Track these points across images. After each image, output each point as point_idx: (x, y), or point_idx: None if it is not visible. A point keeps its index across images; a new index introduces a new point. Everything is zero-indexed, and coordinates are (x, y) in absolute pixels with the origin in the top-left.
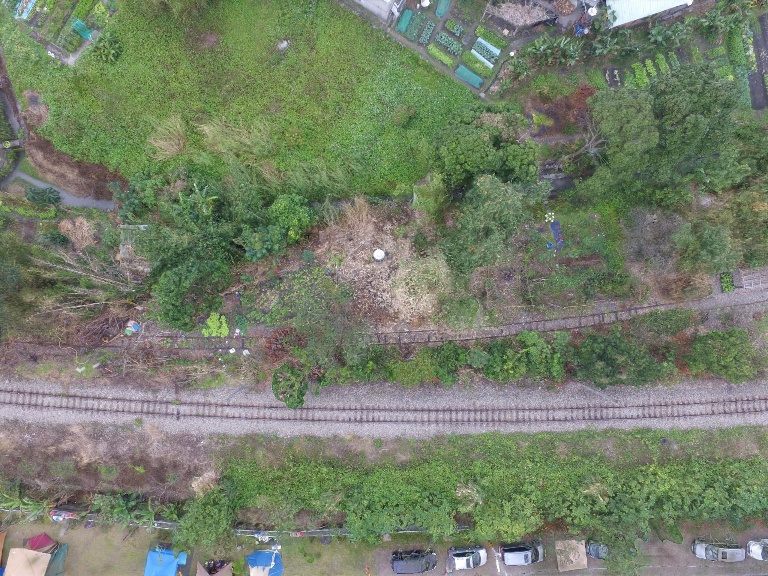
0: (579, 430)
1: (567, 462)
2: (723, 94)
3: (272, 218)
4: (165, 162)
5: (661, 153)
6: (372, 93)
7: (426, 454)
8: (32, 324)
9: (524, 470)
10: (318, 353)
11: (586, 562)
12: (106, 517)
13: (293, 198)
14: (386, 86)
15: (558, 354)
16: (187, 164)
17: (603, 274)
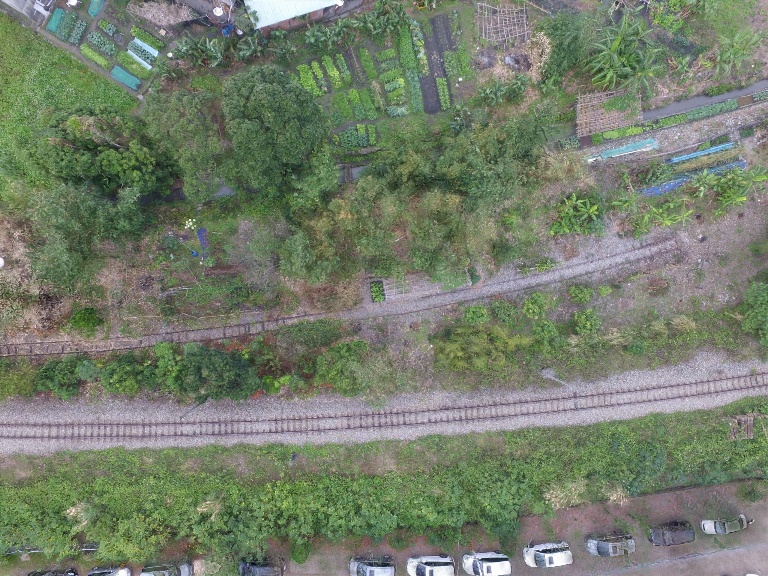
0: (207, 445)
1: (196, 478)
2: (263, 97)
3: None
4: None
5: (243, 158)
6: (21, 94)
7: (46, 471)
8: None
9: (146, 487)
10: None
11: None
12: None
13: None
14: (35, 87)
15: (177, 366)
16: None
17: (251, 283)
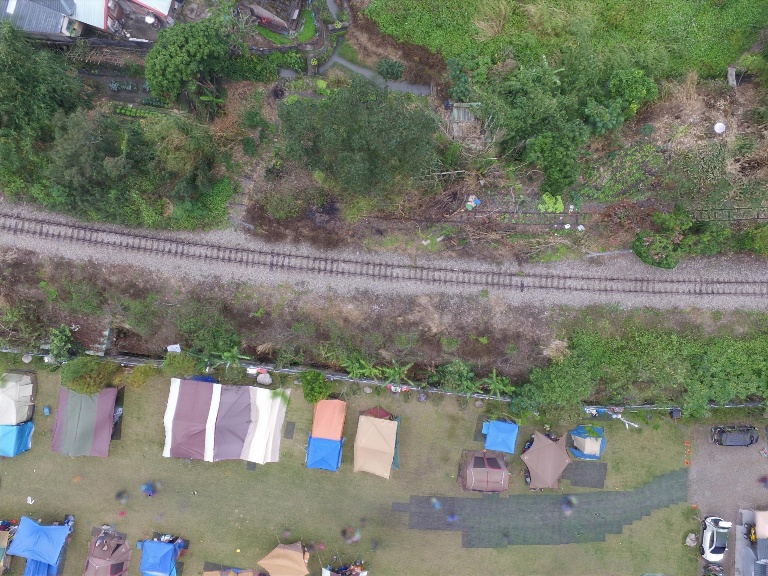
0: None
1: None
2: None
3: None
4: (485, 44)
5: None
6: None
7: (764, 326)
8: (378, 198)
9: None
10: (682, 218)
11: None
12: (455, 385)
13: None
14: None
15: None
16: None
17: None
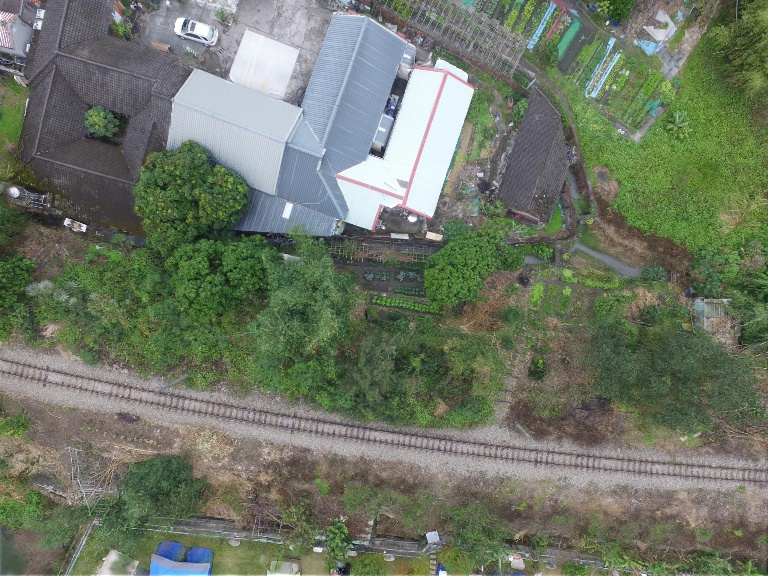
0: None
1: None
2: None
3: None
4: (726, 235)
5: None
6: None
7: None
8: None
9: None
10: None
11: None
12: None
13: None
14: None
15: None
16: (747, 237)
17: None
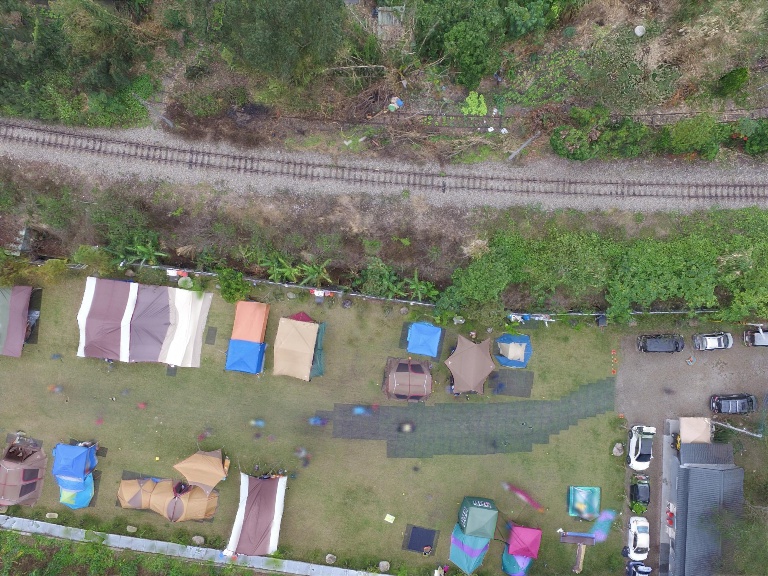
0: None
1: None
2: None
3: (525, 2)
4: None
5: None
6: None
7: (686, 229)
8: (300, 98)
9: None
10: (599, 112)
11: None
12: (376, 285)
13: None
14: None
15: None
16: None
17: None
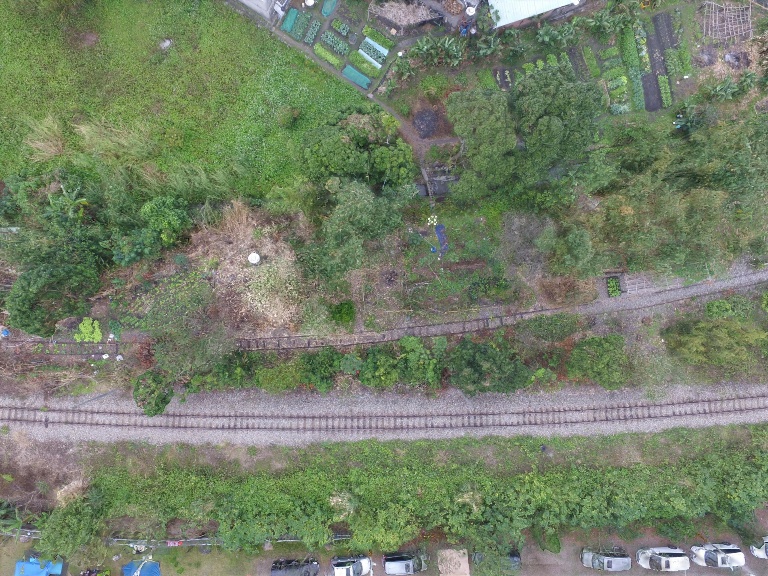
0: (458, 437)
1: (446, 470)
2: (575, 95)
3: None
4: (43, 163)
5: (526, 155)
6: (257, 93)
7: (302, 462)
8: None
9: (401, 478)
10: (182, 359)
11: (468, 571)
12: None
13: (165, 200)
14: (271, 86)
15: (434, 360)
16: (66, 165)
17: (488, 278)
